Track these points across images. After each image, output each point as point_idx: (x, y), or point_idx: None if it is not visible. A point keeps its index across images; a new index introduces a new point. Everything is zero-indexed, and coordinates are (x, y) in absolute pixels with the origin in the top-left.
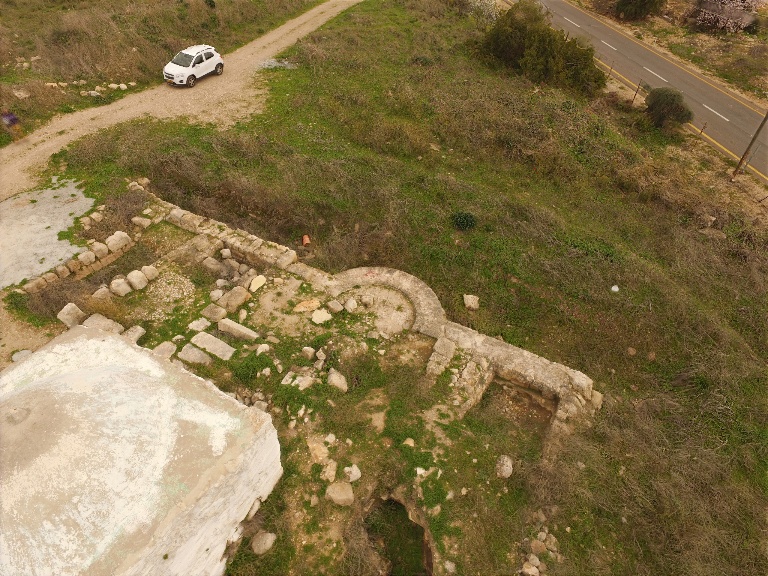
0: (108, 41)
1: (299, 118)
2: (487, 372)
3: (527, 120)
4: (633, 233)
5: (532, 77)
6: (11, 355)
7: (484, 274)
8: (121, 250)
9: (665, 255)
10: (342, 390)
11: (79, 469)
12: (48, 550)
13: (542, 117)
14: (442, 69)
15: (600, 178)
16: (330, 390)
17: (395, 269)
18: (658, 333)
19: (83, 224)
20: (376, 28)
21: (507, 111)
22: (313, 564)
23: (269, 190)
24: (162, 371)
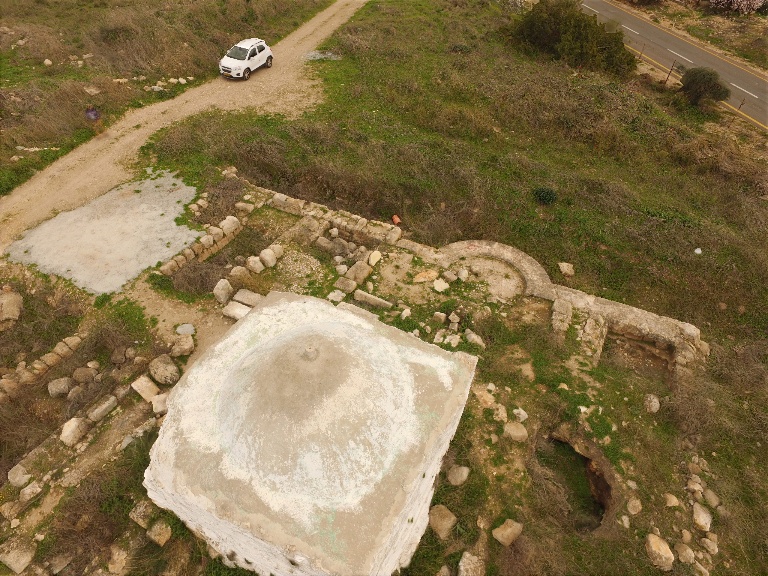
0: (161, 37)
1: (362, 106)
2: (604, 328)
3: (575, 102)
4: (701, 201)
5: (569, 61)
6: (174, 329)
7: (573, 243)
8: (232, 234)
9: (735, 220)
10: (483, 347)
11: (367, 397)
12: (352, 465)
13: (590, 98)
14: (480, 56)
15: (660, 153)
16: (476, 347)
17: (493, 241)
18: (745, 288)
19: (193, 211)
20: (406, 18)
21: (554, 94)
22: (509, 490)
23: (359, 173)
24: (371, 325)
